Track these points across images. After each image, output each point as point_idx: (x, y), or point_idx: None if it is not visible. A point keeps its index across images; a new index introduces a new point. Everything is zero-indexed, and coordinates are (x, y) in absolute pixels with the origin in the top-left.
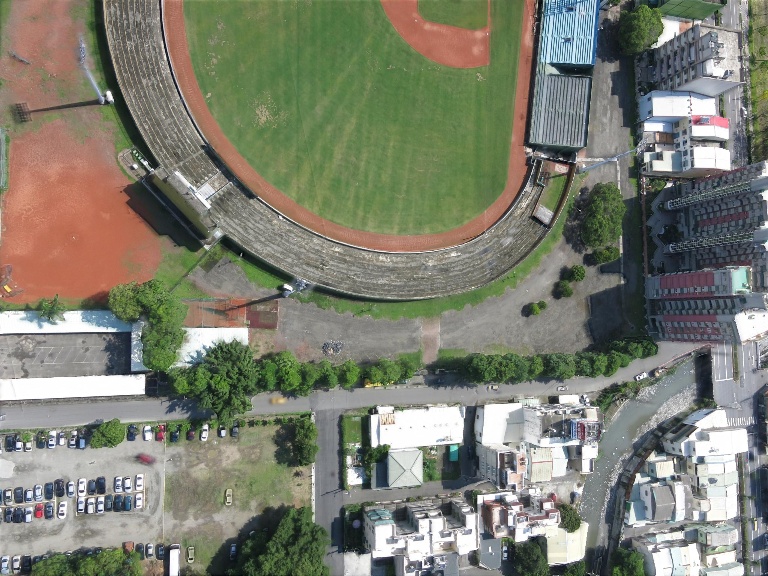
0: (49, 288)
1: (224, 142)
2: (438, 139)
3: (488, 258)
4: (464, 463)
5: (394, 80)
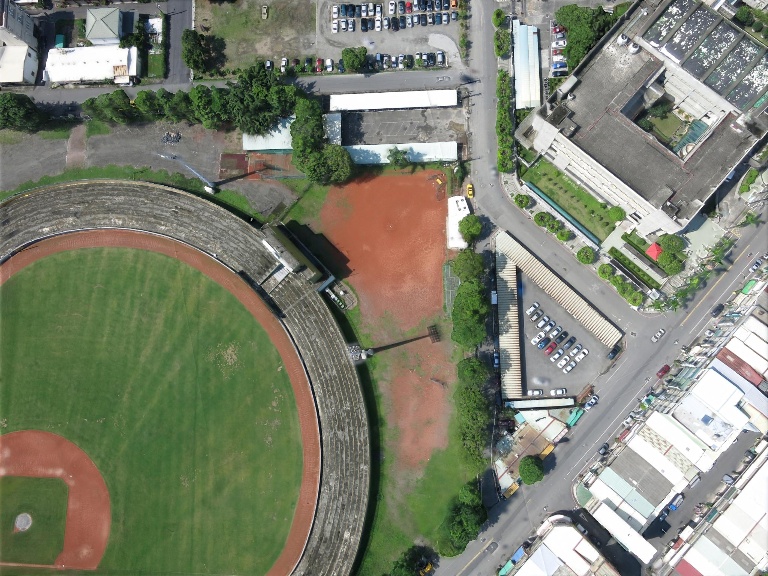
0: (408, 183)
1: (266, 325)
2: (55, 349)
3: (9, 227)
4: (51, 34)
5: (99, 407)
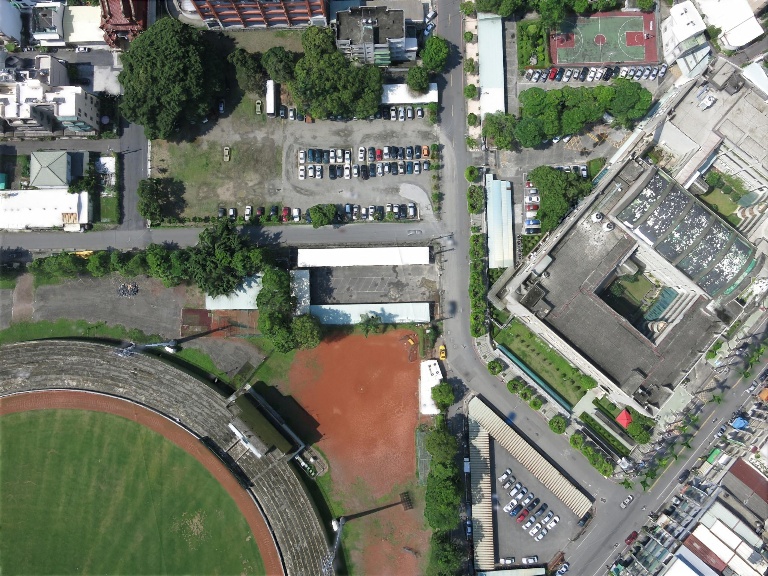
0: (380, 343)
1: (234, 492)
2: (7, 520)
3: None
4: None
5: None
